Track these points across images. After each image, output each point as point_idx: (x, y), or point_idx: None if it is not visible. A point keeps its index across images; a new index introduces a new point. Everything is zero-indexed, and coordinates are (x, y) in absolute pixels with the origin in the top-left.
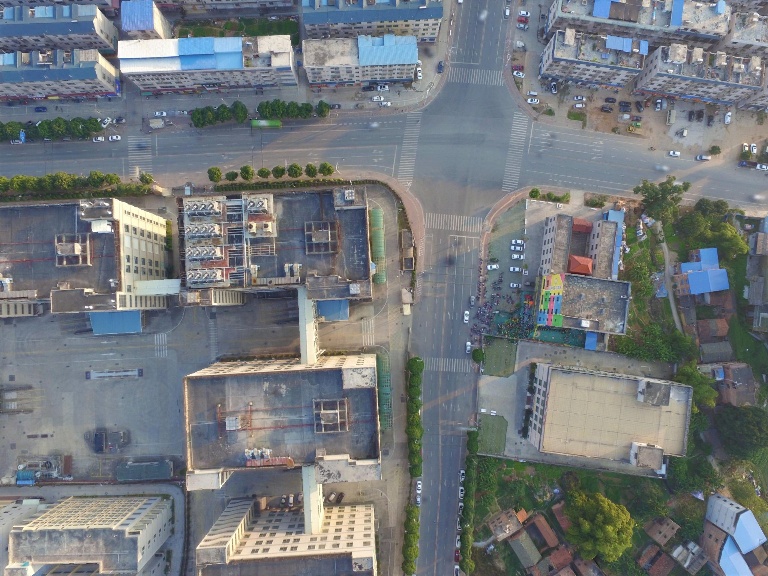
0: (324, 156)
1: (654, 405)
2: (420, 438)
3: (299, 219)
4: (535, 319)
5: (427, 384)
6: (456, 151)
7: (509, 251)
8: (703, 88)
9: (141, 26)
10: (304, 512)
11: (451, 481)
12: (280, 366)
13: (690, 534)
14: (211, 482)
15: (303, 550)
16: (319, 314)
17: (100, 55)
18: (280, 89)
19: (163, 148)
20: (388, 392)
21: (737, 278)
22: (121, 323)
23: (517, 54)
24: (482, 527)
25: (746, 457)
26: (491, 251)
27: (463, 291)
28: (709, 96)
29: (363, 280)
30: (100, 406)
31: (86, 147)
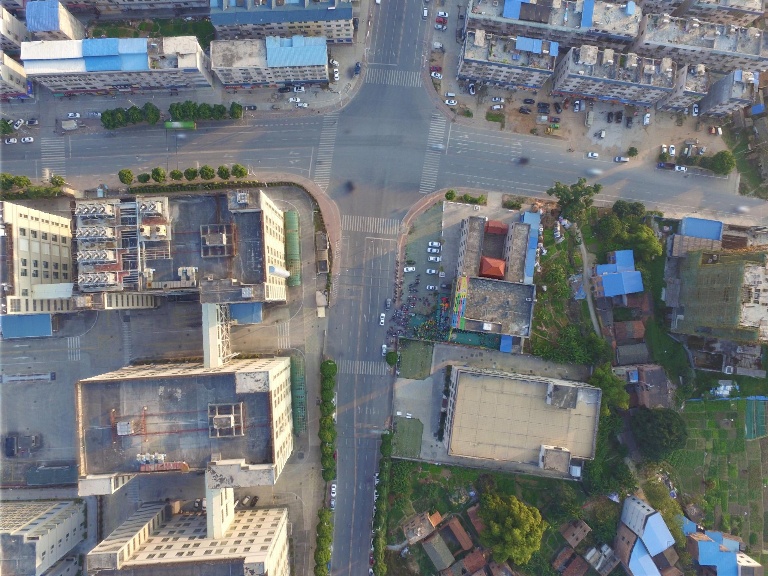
0: (240, 158)
1: (561, 408)
2: (332, 441)
3: (196, 222)
4: (449, 321)
5: (343, 387)
6: (373, 153)
7: (426, 253)
8: (617, 89)
9: (46, 27)
10: None
11: (366, 484)
12: (181, 370)
13: (603, 536)
14: (103, 487)
15: (198, 555)
16: (231, 317)
17: (7, 56)
18: (195, 90)
19: (77, 150)
20: (302, 395)
21: (655, 280)
22: (31, 326)
23: (435, 55)
24: (397, 530)
25: (658, 459)
26: (408, 253)
27: (379, 293)
28: (626, 97)
29: (259, 284)
30: (12, 410)
31: None
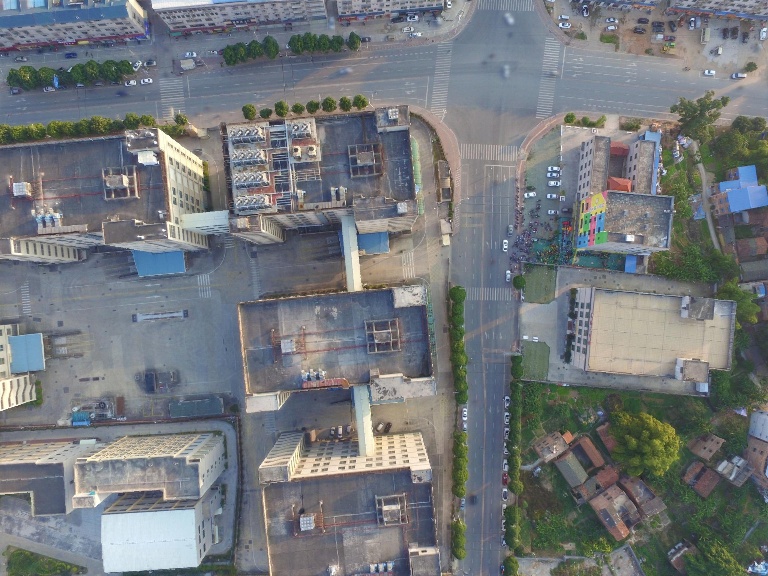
0: (356, 90)
1: (699, 319)
2: (465, 365)
3: (342, 143)
4: (575, 244)
5: (469, 314)
6: (488, 80)
7: (545, 178)
8: (739, 1)
9: None
10: (358, 435)
11: (496, 407)
12: None
13: (734, 448)
14: (270, 404)
15: (361, 468)
16: (360, 247)
17: None
18: (309, 24)
19: (195, 89)
20: (431, 322)
21: None
22: (165, 264)
23: None
24: (528, 451)
25: None
26: (527, 179)
27: (501, 220)
28: (744, 11)
29: (409, 201)
30: (148, 348)
31: (118, 92)
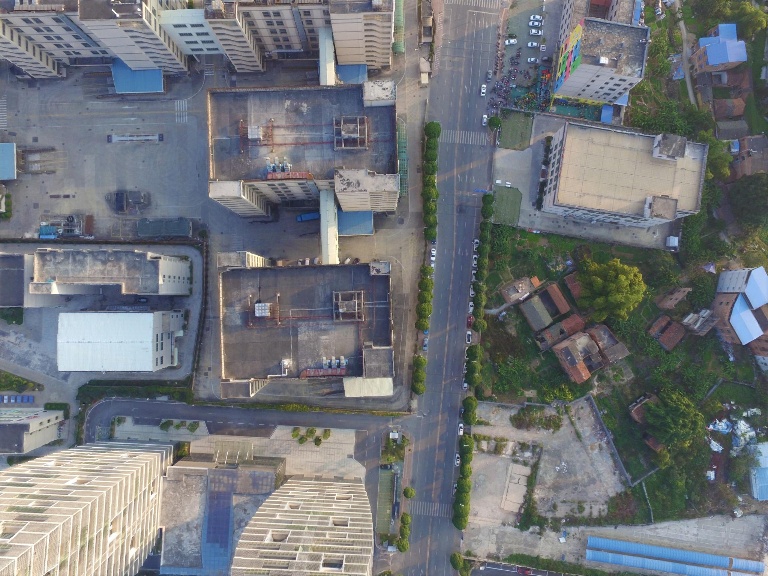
0: None
1: (669, 156)
2: (436, 199)
3: None
4: (552, 89)
5: (443, 155)
6: None
7: (527, 27)
8: None
9: None
10: (322, 246)
11: (465, 250)
12: None
13: (701, 300)
14: (233, 189)
15: None
16: (338, 78)
17: None
18: None
19: None
20: (404, 158)
21: (755, 60)
22: (143, 82)
23: None
24: (495, 295)
25: (759, 223)
26: (509, 27)
27: (481, 66)
28: None
29: None
30: (121, 169)
31: None
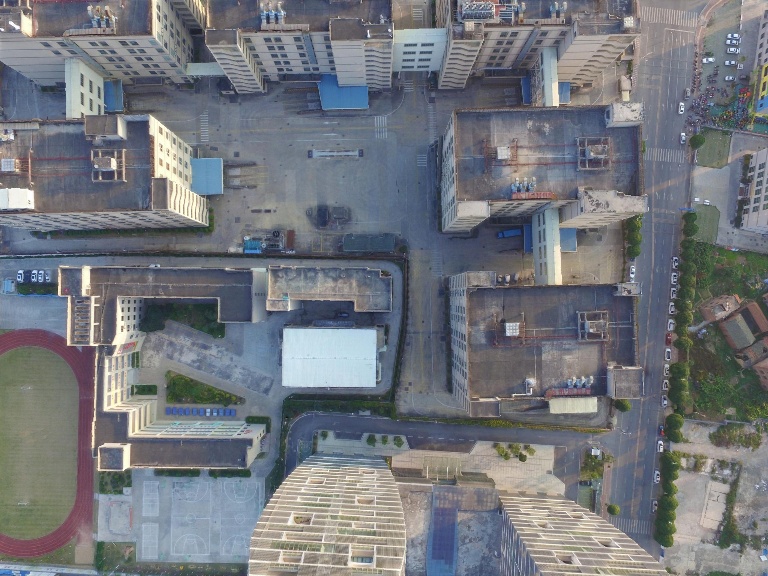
0: None
1: None
2: None
3: None
4: (754, 107)
5: None
6: None
7: (724, 46)
8: None
9: None
10: (547, 264)
11: (663, 267)
12: None
13: None
14: (481, 209)
15: None
16: None
17: None
18: None
19: None
20: None
21: None
22: (349, 98)
23: None
24: (694, 312)
25: None
26: (706, 45)
27: (678, 84)
28: None
29: None
30: (321, 184)
31: None
